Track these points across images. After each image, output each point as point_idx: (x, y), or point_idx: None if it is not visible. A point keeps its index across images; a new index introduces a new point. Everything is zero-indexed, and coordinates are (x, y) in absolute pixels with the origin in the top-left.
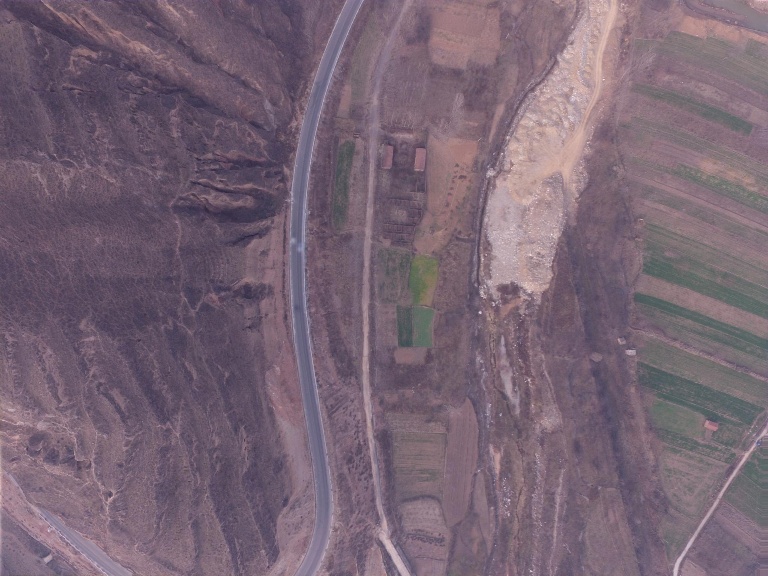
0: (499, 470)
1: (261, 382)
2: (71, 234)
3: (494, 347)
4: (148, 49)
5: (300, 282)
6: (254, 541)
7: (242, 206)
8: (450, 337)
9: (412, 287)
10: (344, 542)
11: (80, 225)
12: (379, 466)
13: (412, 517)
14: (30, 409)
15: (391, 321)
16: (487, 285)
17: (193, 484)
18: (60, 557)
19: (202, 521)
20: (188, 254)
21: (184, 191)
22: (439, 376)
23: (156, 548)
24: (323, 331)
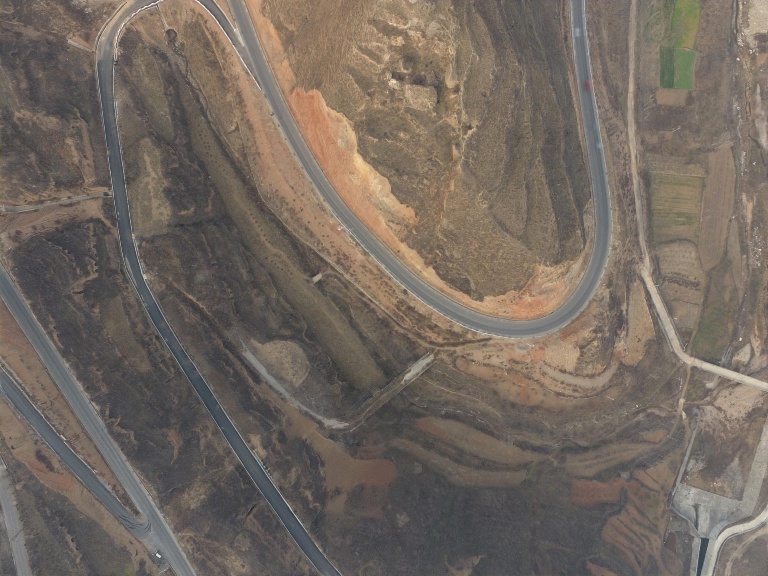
0: (751, 219)
1: (567, 75)
2: None
3: (750, 95)
4: None
5: (580, 5)
6: (571, 220)
7: None
8: (711, 80)
9: (674, 29)
10: (620, 263)
11: None
12: (642, 202)
13: (669, 260)
14: (430, 2)
15: (654, 61)
16: (744, 34)
17: (531, 141)
18: (331, 275)
19: (532, 186)
20: None
21: None
22: (699, 118)
23: (493, 204)
24: (597, 58)
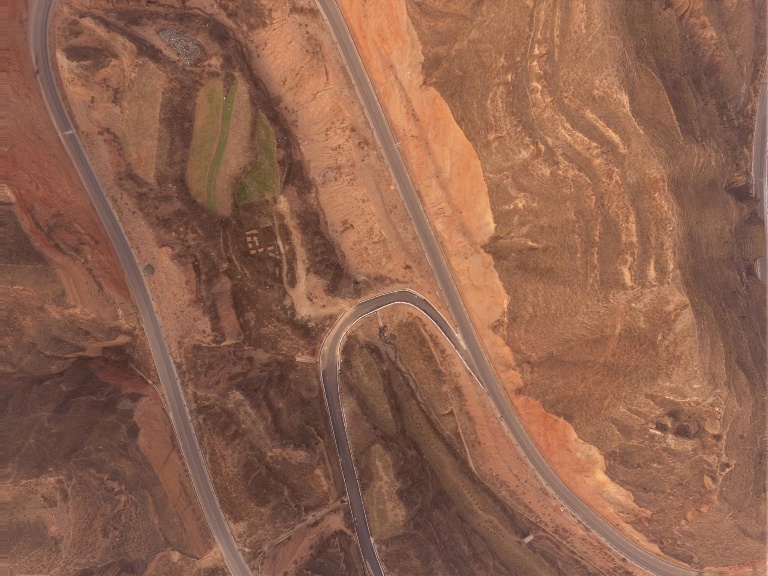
0: None
1: None
2: (705, 216)
3: None
4: (712, 34)
5: (766, 259)
6: None
7: (733, 187)
8: None
9: None
10: None
11: (707, 207)
12: None
13: None
14: (711, 384)
15: None
16: None
17: None
18: (542, 537)
19: (767, 488)
20: (738, 234)
21: (732, 173)
22: None
23: None
24: None
